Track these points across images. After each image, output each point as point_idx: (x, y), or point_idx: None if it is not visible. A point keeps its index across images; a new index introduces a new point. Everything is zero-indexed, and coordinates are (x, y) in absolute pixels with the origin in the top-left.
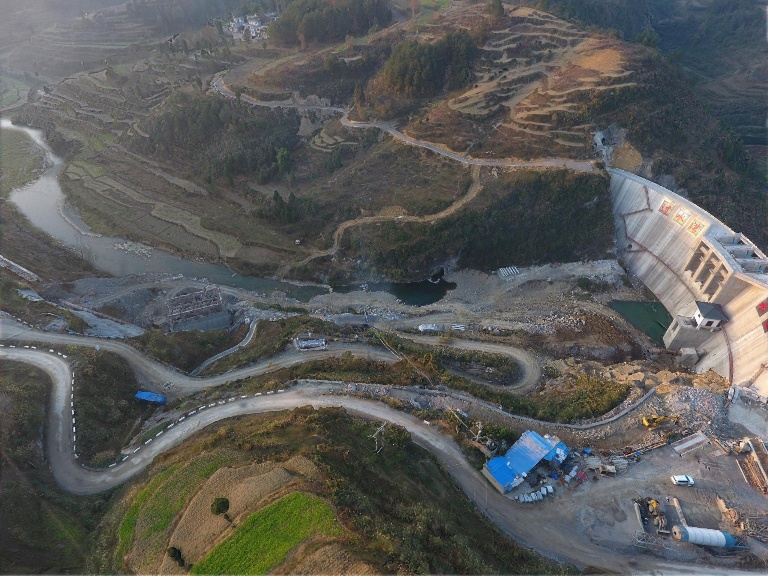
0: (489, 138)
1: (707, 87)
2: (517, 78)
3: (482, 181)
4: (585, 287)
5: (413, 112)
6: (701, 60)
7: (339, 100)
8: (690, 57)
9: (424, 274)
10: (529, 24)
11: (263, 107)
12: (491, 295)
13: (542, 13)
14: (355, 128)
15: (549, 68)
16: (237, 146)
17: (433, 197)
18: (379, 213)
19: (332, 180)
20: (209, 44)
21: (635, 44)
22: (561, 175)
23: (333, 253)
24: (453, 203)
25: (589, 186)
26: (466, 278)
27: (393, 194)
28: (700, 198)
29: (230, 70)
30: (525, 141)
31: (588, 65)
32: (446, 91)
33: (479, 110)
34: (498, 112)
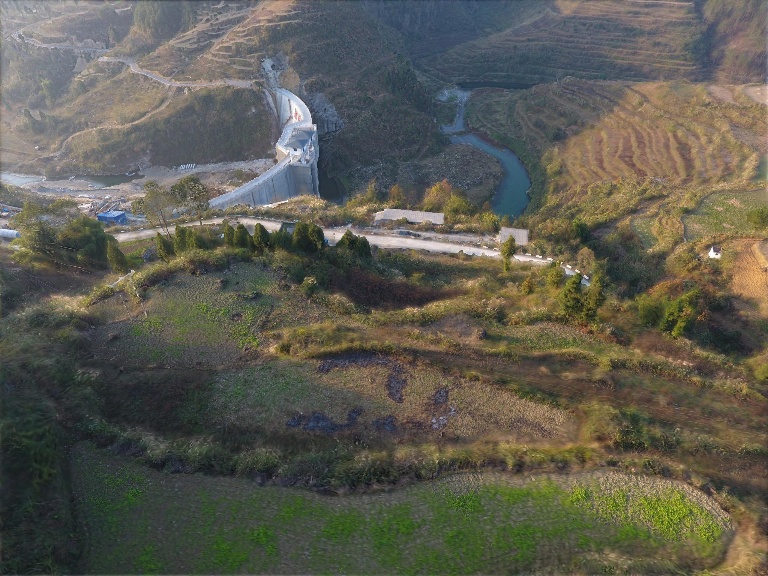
0: (191, 66)
1: (474, 41)
2: (226, 20)
3: (173, 97)
4: (240, 177)
5: (154, 50)
6: (501, 22)
7: (113, 44)
8: (496, 20)
9: (121, 169)
10: None
11: (43, 48)
12: (164, 182)
13: None
14: (104, 62)
15: (252, 12)
16: (18, 79)
17: (135, 110)
18: (100, 125)
19: (75, 102)
20: (36, 2)
21: None
22: (223, 90)
23: (57, 154)
24: (147, 114)
25: (243, 98)
26: (154, 172)
27: (113, 110)
28: (343, 111)
29: (37, 22)
30: (212, 67)
31: (270, 7)
32: (180, 32)
33: (190, 45)
34: (206, 46)
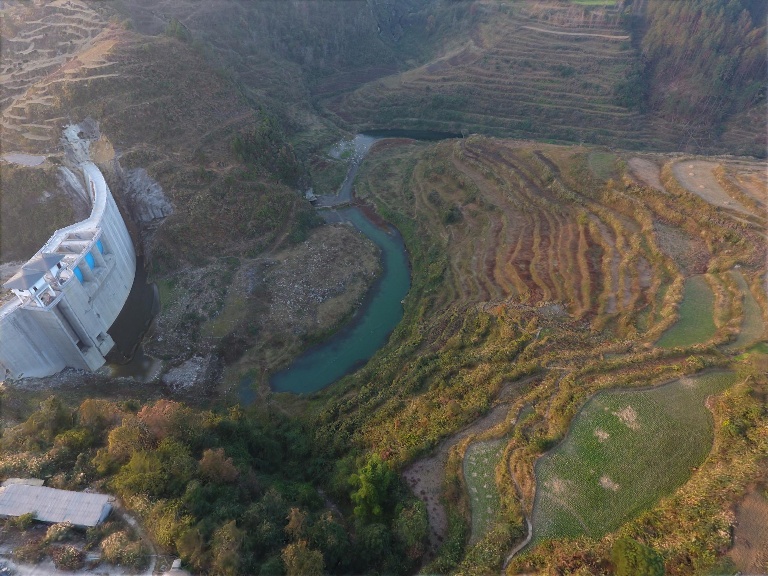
0: None
1: None
2: (32, 70)
3: None
4: None
5: None
6: (425, 53)
7: None
8: (420, 50)
9: None
10: (60, 14)
11: None
12: None
13: (74, 3)
14: None
15: (67, 60)
16: None
17: None
18: None
19: None
20: None
21: (143, 34)
22: (3, 170)
23: None
24: None
25: (29, 181)
26: None
27: None
28: (171, 192)
29: None
30: (0, 135)
31: (81, 56)
32: None
33: None
34: (3, 105)
